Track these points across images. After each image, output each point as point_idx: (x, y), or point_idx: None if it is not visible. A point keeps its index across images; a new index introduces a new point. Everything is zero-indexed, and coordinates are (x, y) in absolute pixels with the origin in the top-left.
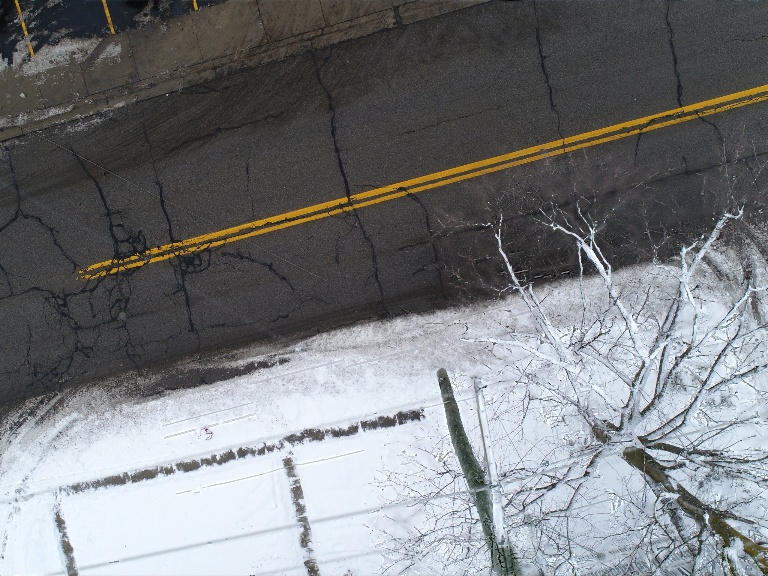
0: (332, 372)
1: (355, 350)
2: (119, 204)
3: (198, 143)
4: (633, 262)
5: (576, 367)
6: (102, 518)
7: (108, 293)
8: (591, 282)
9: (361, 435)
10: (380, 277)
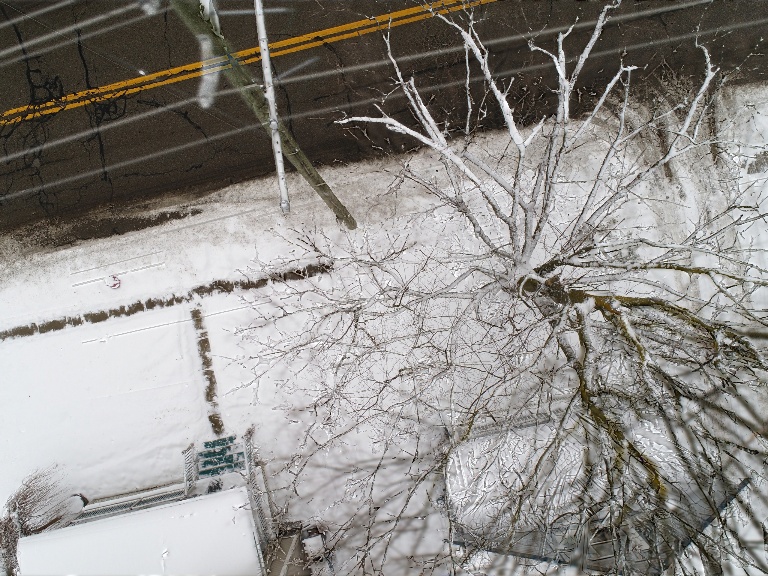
0: (243, 222)
1: (267, 201)
2: (37, 49)
3: None
4: None
5: (448, 148)
6: (7, 367)
7: (23, 139)
8: (504, 136)
9: None
10: (294, 128)
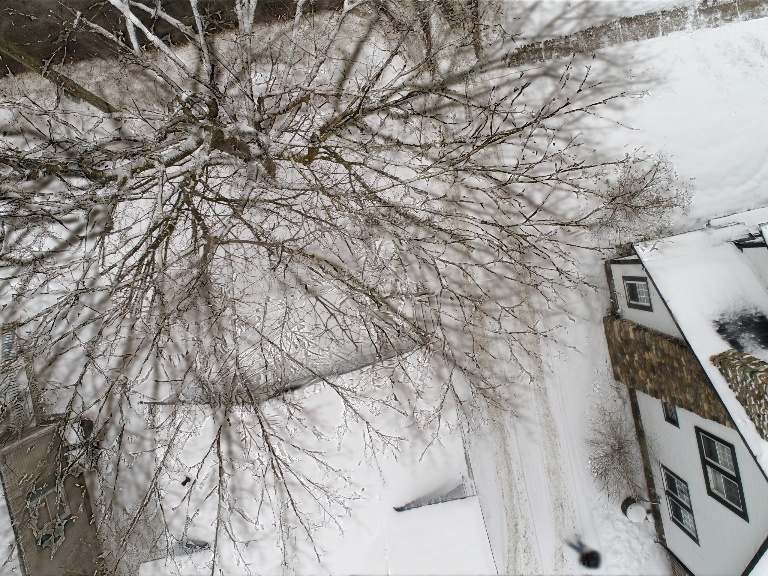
0: None
1: None
2: None
3: None
4: None
5: None
6: None
7: None
8: (270, 28)
9: (40, 179)
10: None
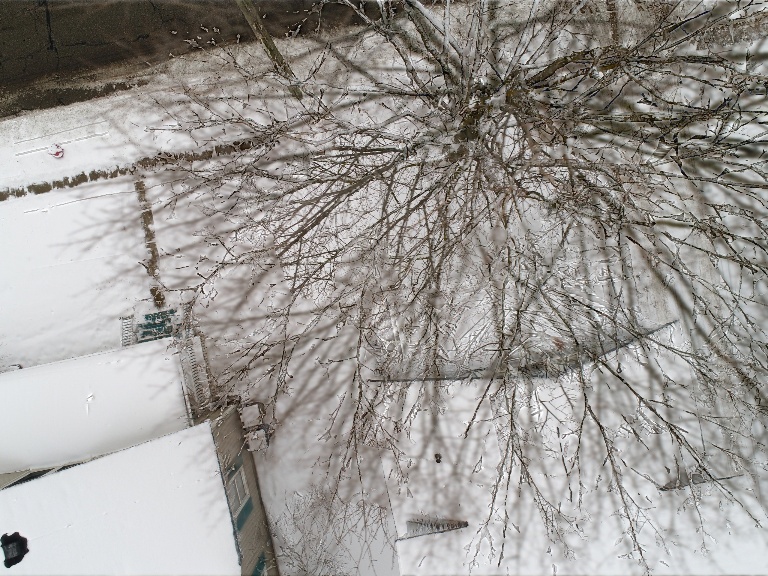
0: None
1: (214, 73)
2: None
3: None
4: None
5: None
6: None
7: None
8: None
9: (214, 159)
10: None
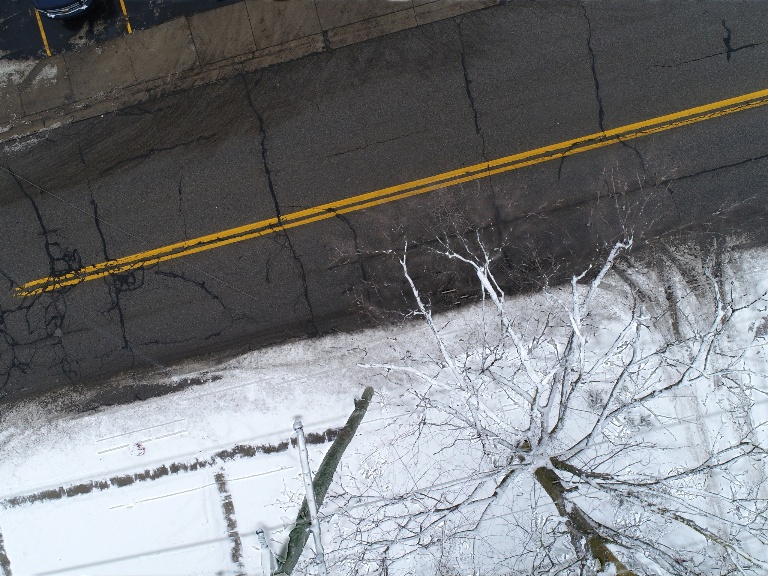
0: (262, 389)
1: (285, 368)
2: (55, 223)
3: (132, 163)
4: (557, 283)
5: (468, 393)
6: (37, 532)
7: (44, 310)
8: (516, 302)
9: (291, 452)
10: (310, 296)
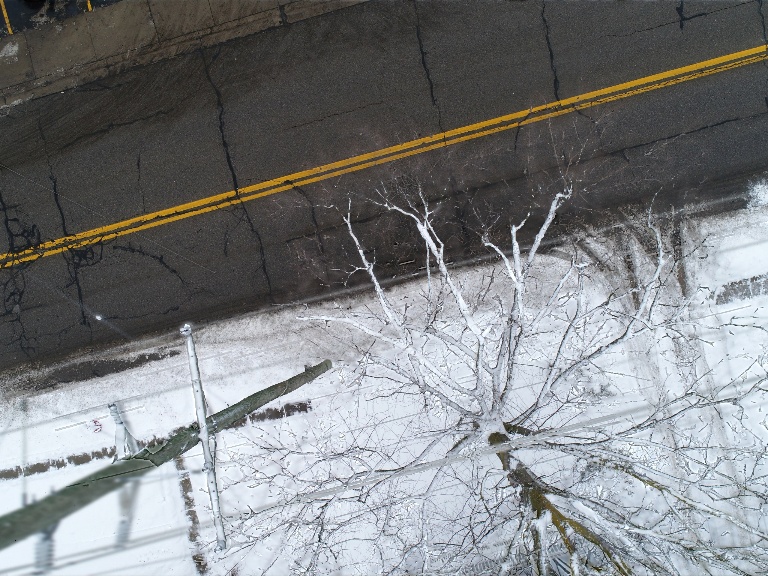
0: (220, 364)
1: (243, 342)
2: (14, 199)
3: (91, 139)
4: None
5: (407, 344)
6: None
7: (3, 286)
8: (474, 273)
9: (249, 427)
10: (268, 269)
